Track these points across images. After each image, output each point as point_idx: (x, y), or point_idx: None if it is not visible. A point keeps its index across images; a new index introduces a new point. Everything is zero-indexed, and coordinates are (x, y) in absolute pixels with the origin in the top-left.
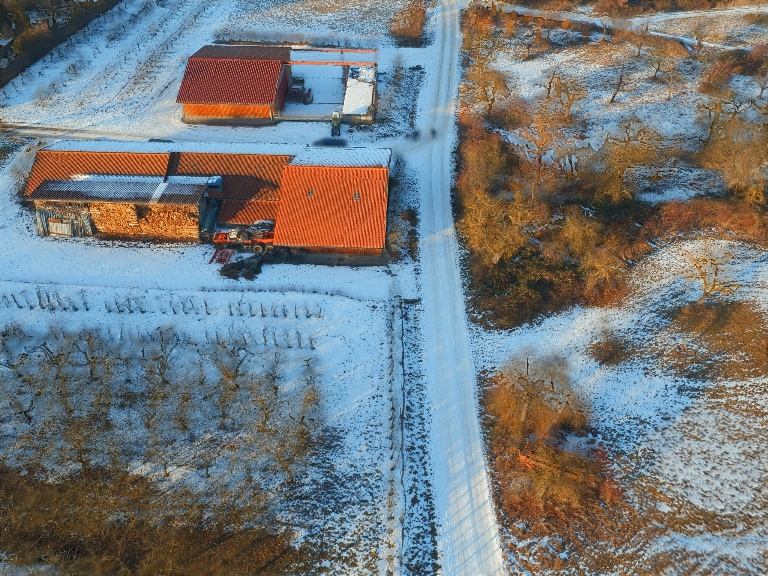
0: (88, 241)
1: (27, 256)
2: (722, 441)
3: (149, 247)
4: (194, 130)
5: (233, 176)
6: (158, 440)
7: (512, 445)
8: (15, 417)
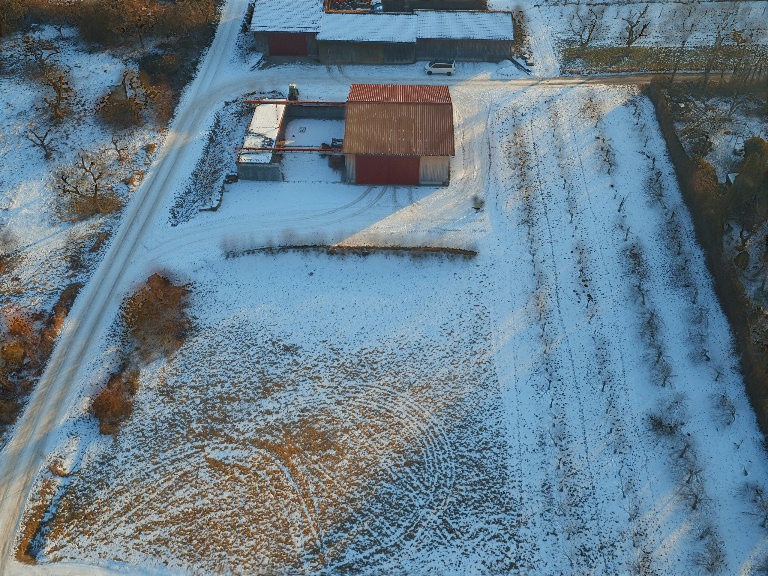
0: None
1: None
2: None
3: None
4: None
5: None
6: None
7: None
8: None
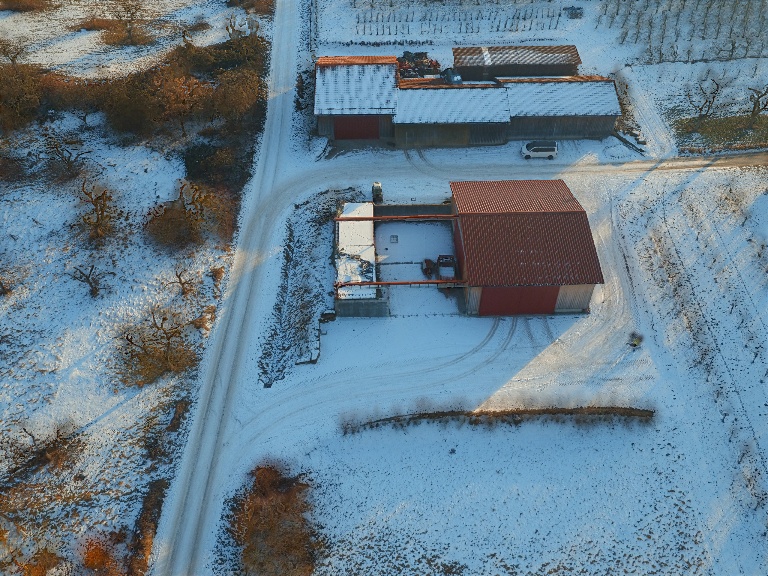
0: None
1: None
2: (169, 3)
3: None
4: None
5: None
6: None
7: None
8: None
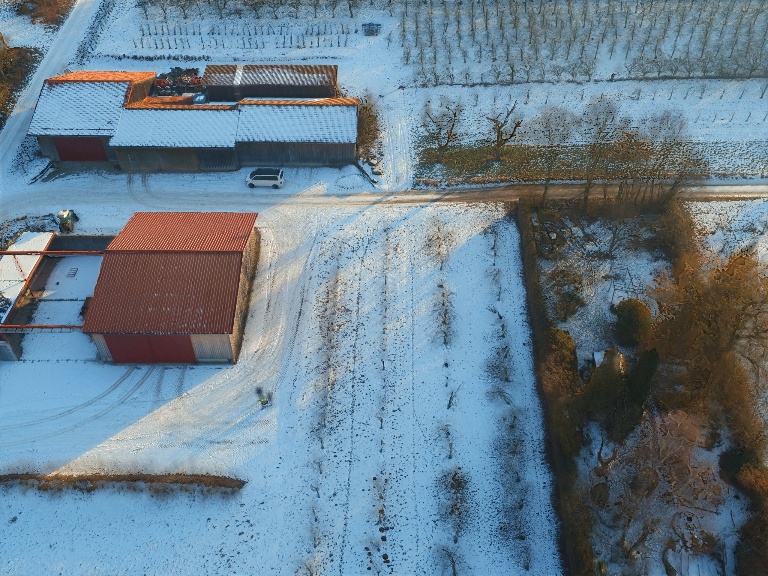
0: None
1: None
2: None
3: None
4: None
5: None
6: (220, 1)
7: (59, 7)
8: None
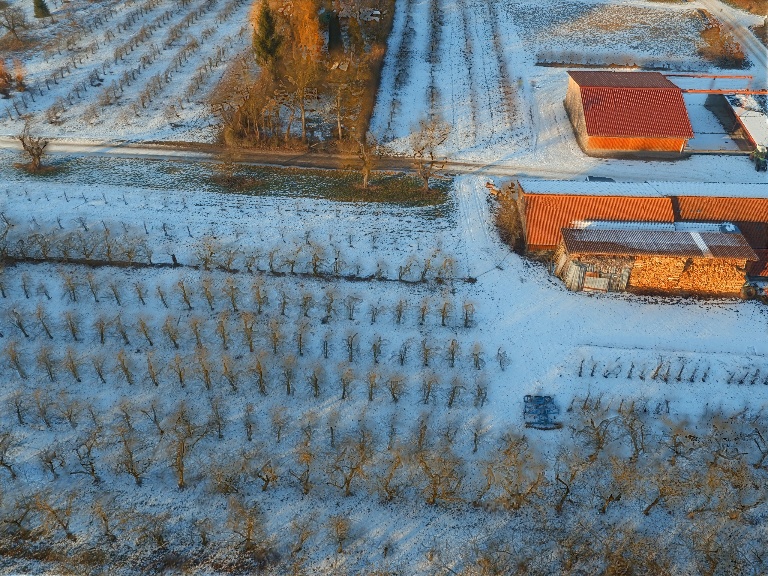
0: (627, 297)
1: (579, 315)
2: None
3: (695, 304)
4: (609, 165)
5: (745, 222)
6: None
7: None
8: (761, 517)
